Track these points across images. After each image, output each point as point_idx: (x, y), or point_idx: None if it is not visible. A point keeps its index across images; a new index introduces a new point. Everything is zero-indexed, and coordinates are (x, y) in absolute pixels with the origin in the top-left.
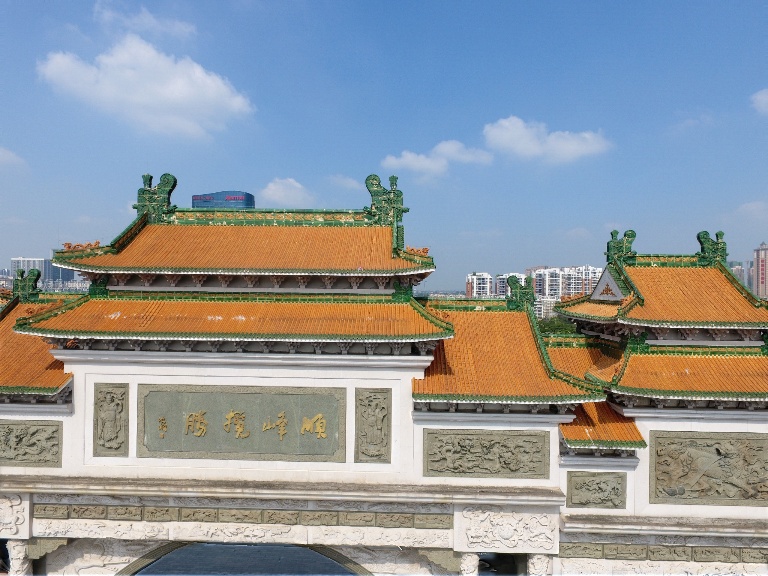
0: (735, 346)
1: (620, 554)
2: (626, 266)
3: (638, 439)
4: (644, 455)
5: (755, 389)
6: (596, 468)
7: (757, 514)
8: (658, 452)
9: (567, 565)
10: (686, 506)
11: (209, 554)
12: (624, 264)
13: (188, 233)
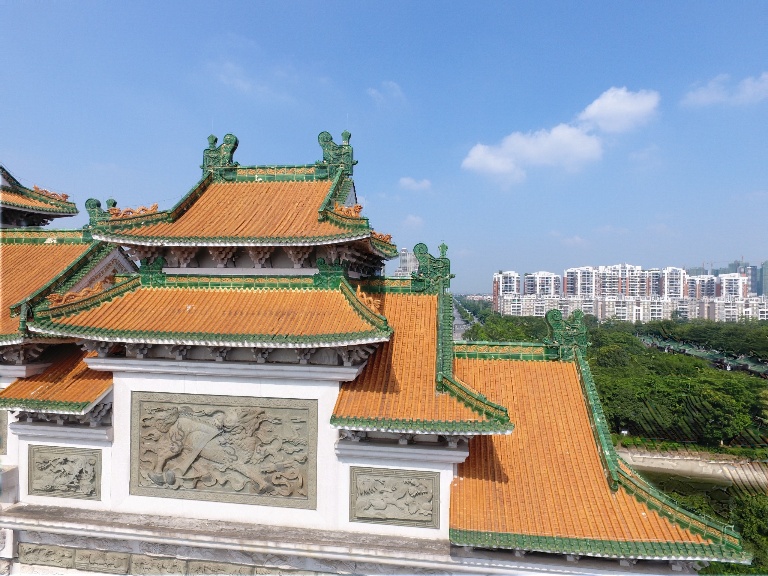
0: (278, 275)
1: (93, 564)
2: (224, 182)
3: (83, 400)
4: (123, 425)
5: (244, 330)
6: (64, 442)
7: (272, 518)
8: (140, 422)
9: (24, 574)
10: (177, 501)
11: None
12: (221, 179)
13: None
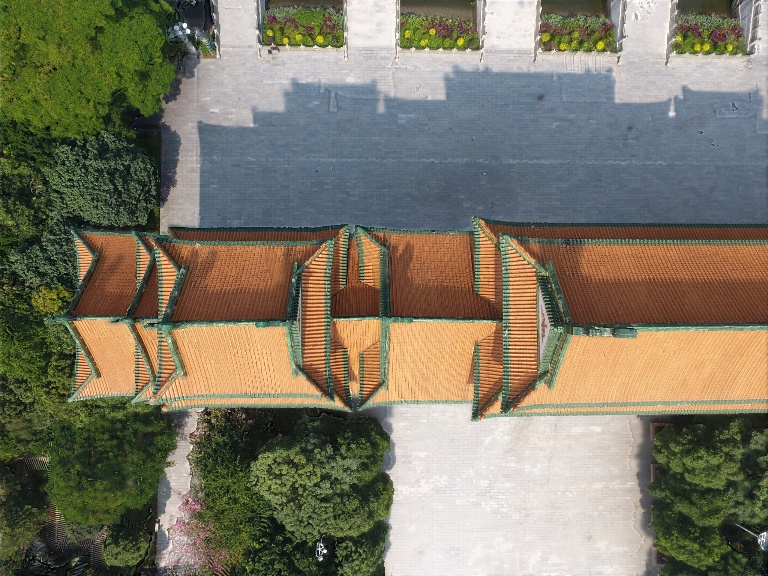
0: None
1: None
2: None
3: None
4: None
5: None
6: None
7: None
8: None
9: None
10: None
11: (408, 135)
12: None
13: (620, 344)
